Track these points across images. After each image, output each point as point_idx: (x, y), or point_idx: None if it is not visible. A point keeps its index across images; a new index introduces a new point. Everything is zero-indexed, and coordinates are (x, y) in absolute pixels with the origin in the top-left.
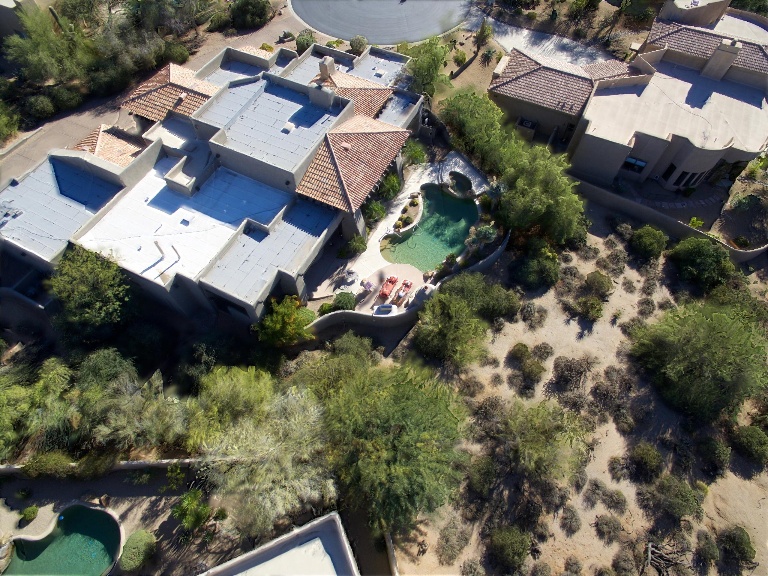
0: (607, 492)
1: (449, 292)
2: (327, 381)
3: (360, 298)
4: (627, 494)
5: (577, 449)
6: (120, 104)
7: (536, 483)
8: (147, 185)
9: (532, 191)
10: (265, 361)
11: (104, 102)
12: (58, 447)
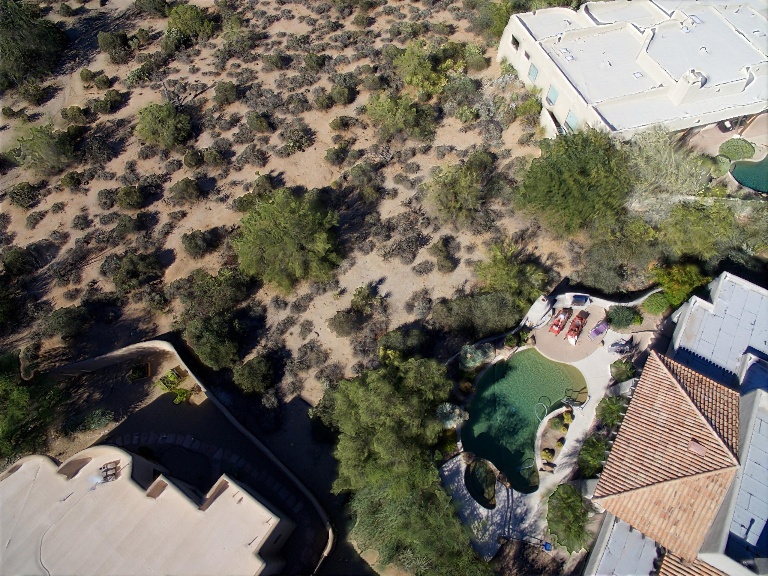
0: (407, 181)
1: (514, 310)
2: None
3: None
4: (391, 183)
5: None
6: None
7: None
8: None
9: None
10: (683, 267)
11: None
12: None
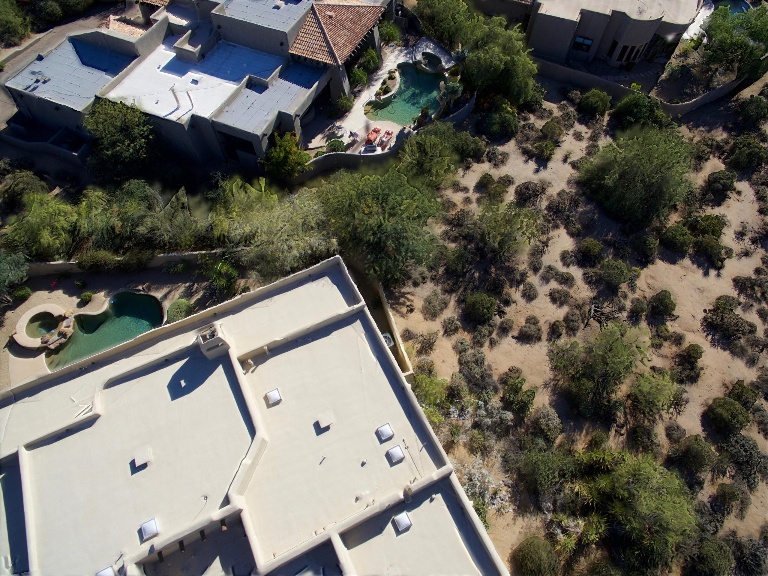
0: (559, 272)
1: (425, 135)
2: (325, 197)
3: (349, 146)
4: (575, 275)
5: (534, 244)
6: (121, 10)
7: (501, 268)
8: (158, 56)
9: (492, 50)
10: (271, 189)
11: (107, 8)
12: (104, 249)
